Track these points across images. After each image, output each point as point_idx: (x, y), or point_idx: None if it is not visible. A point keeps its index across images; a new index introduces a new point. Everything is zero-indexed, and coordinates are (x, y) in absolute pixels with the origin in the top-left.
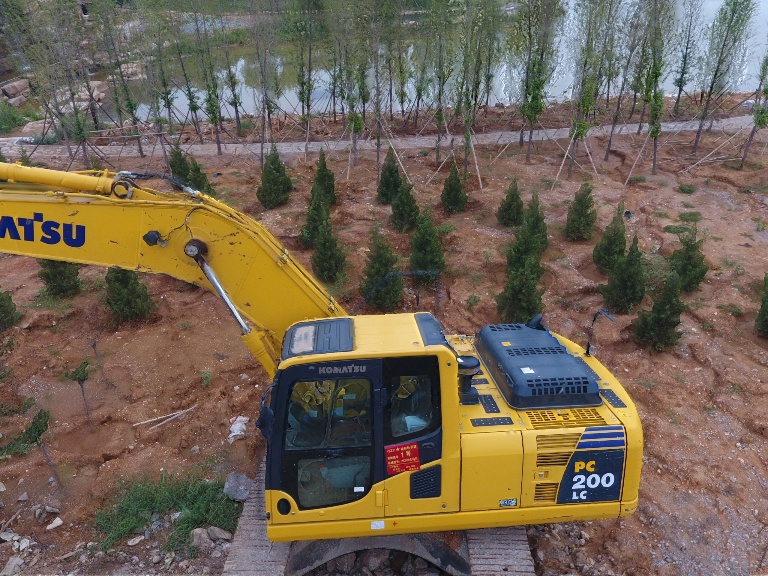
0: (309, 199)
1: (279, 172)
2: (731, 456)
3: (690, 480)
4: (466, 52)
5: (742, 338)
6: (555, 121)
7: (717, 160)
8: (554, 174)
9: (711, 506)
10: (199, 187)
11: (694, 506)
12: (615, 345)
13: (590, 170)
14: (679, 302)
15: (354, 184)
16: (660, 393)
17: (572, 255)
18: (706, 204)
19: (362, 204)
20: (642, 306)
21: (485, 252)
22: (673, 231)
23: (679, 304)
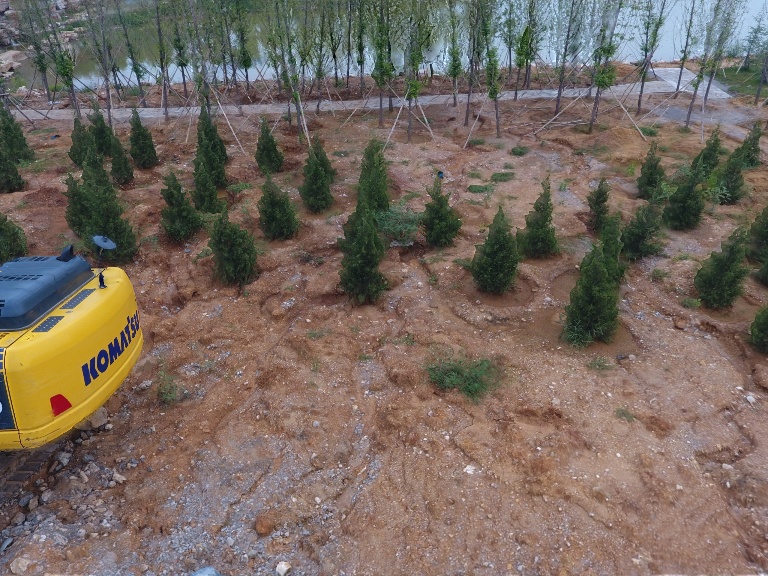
0: (132, 160)
1: (103, 132)
2: (347, 403)
3: (277, 425)
4: (283, 6)
5: (455, 291)
6: (447, 89)
7: (570, 124)
8: (396, 137)
9: (278, 450)
10: (12, 146)
11: (257, 450)
12: (325, 298)
13: (438, 134)
14: (371, 251)
15: (187, 146)
16: (318, 342)
17: (348, 212)
18: (528, 165)
19: (177, 164)
20: (384, 261)
21: (243, 207)
22: (474, 190)
23: (371, 253)
